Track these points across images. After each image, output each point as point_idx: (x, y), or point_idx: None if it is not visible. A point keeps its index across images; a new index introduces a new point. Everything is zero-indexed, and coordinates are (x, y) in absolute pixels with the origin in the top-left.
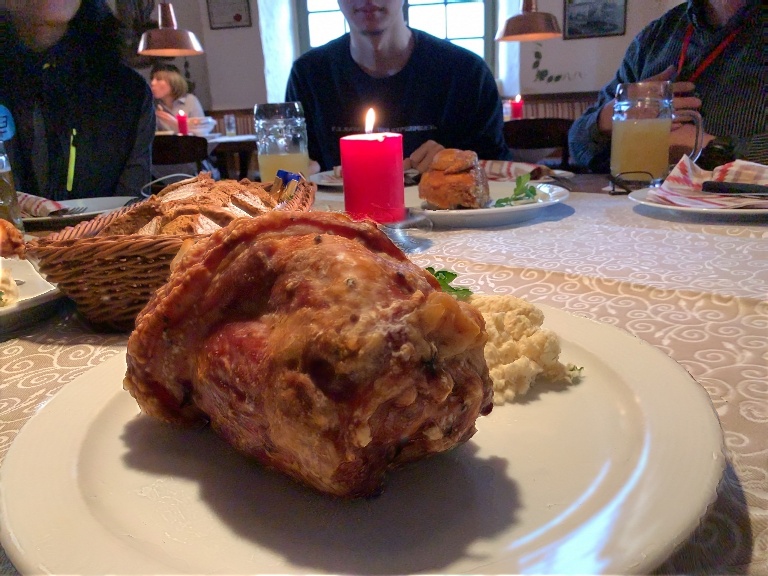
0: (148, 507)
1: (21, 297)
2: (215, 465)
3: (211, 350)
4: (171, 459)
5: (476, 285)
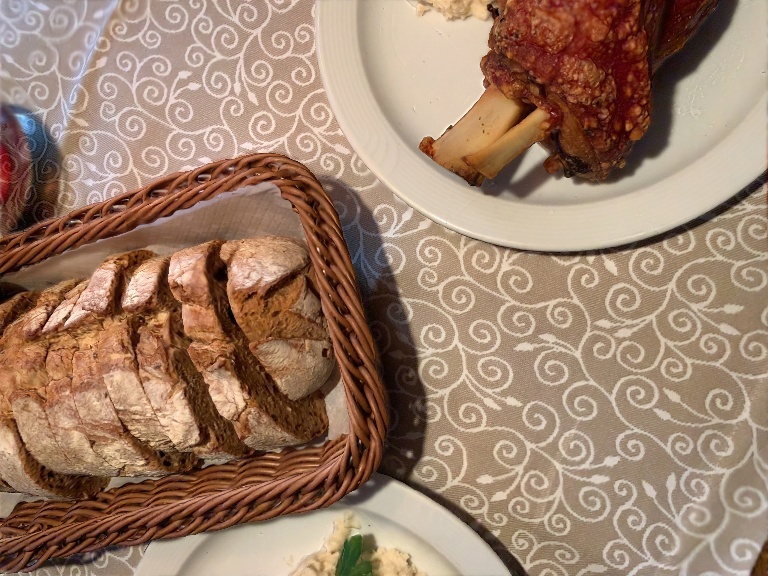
0: (712, 99)
1: (286, 573)
2: (655, 82)
3: (684, 26)
4: (654, 118)
5: (189, 1)
